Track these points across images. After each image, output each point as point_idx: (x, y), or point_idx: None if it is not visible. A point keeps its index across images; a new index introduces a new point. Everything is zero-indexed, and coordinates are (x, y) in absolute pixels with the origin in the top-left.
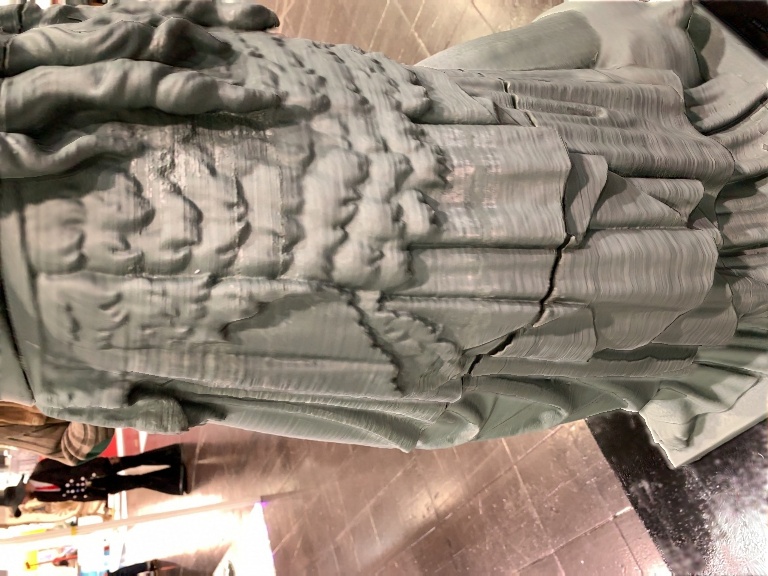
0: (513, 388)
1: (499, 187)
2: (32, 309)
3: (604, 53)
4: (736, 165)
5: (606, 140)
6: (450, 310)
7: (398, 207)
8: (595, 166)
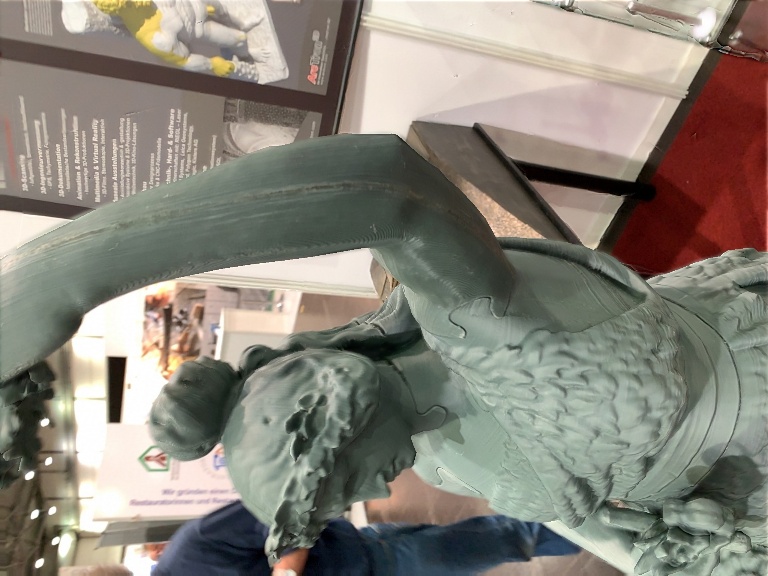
0: None
1: None
2: (666, 286)
3: None
4: None
5: None
6: None
7: None
8: None
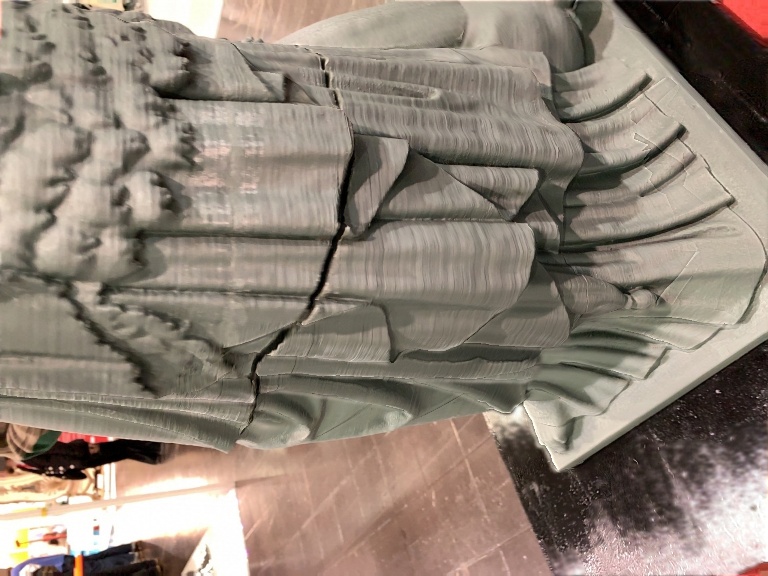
0: (329, 388)
1: (262, 171)
2: None
3: (470, 32)
4: (599, 155)
5: (427, 123)
6: (194, 305)
7: (122, 190)
8: (392, 151)
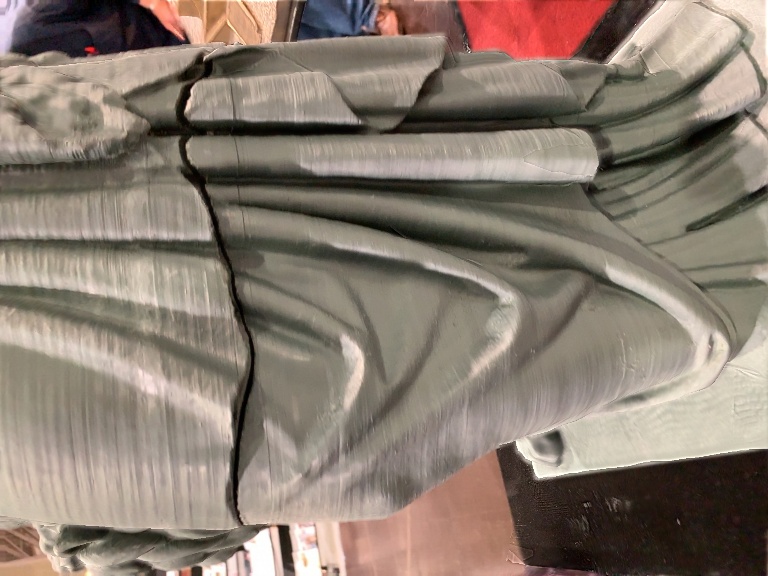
0: (327, 227)
1: None
2: None
3: None
4: None
5: None
6: None
7: None
8: None
